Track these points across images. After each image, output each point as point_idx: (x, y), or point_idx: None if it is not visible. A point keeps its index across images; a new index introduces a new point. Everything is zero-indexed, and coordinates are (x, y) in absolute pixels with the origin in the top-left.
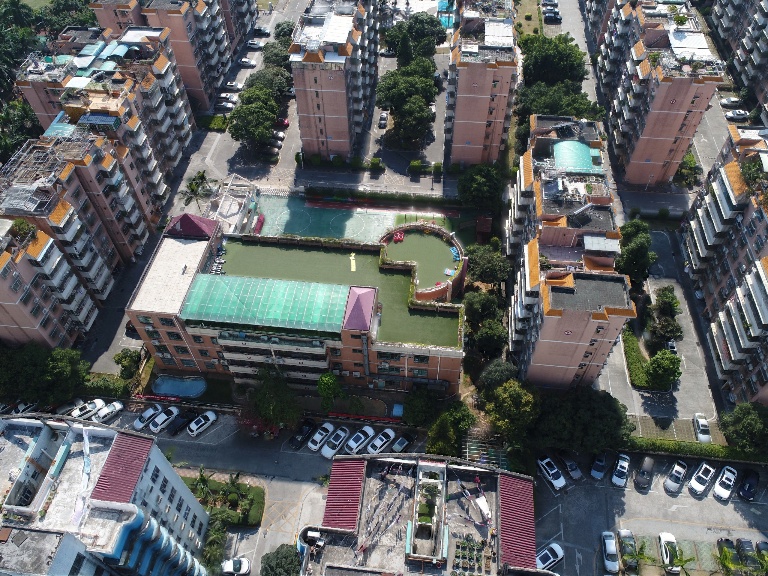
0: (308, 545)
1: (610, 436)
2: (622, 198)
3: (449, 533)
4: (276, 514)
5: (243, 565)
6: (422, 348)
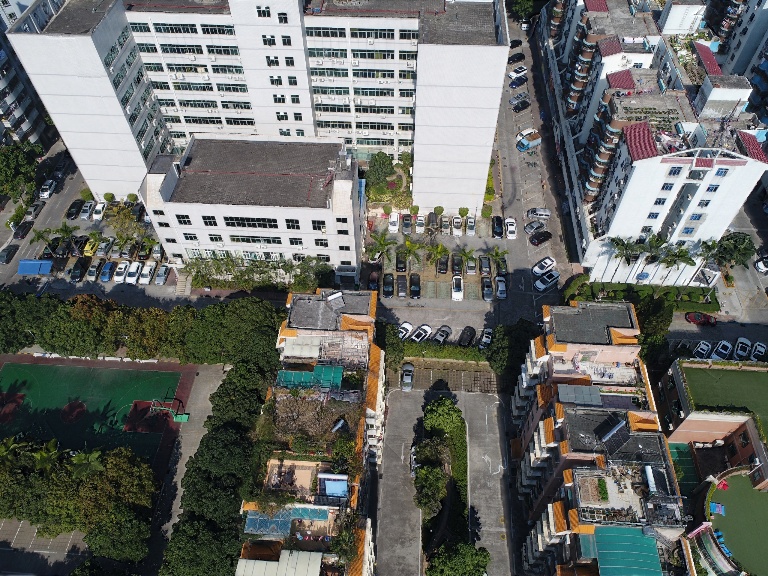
0: (760, 124)
1: None
2: None
3: (678, 137)
4: (759, 300)
5: (763, 265)
6: (718, 362)
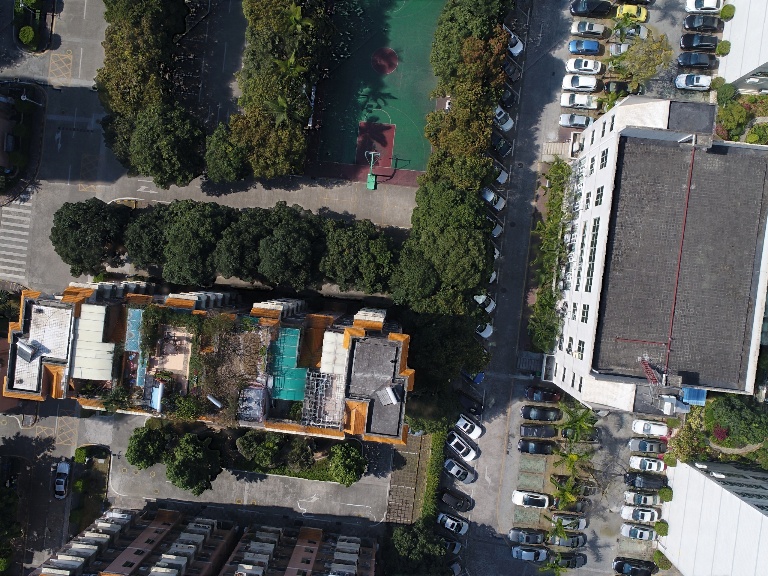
0: None
1: (442, 568)
2: (54, 413)
3: None
4: None
5: None
6: None
